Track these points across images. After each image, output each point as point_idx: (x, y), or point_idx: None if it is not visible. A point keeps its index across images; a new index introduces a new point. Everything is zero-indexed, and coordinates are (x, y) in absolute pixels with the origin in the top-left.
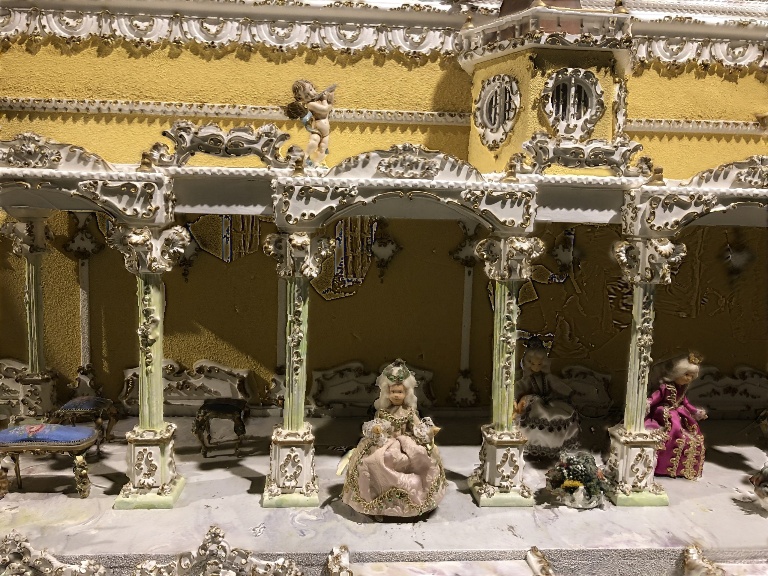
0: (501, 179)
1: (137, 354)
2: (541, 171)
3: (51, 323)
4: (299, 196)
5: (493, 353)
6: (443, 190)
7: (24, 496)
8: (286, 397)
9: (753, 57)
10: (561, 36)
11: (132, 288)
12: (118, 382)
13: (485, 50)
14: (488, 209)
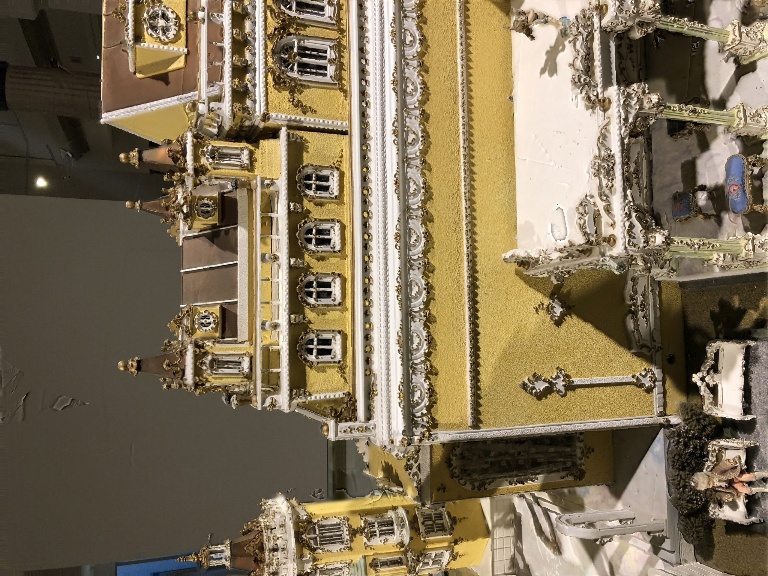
0: None
1: None
2: None
3: None
4: (621, 5)
5: None
6: None
7: (767, 197)
8: (712, 37)
9: None
10: None
11: None
12: None
13: None
14: None
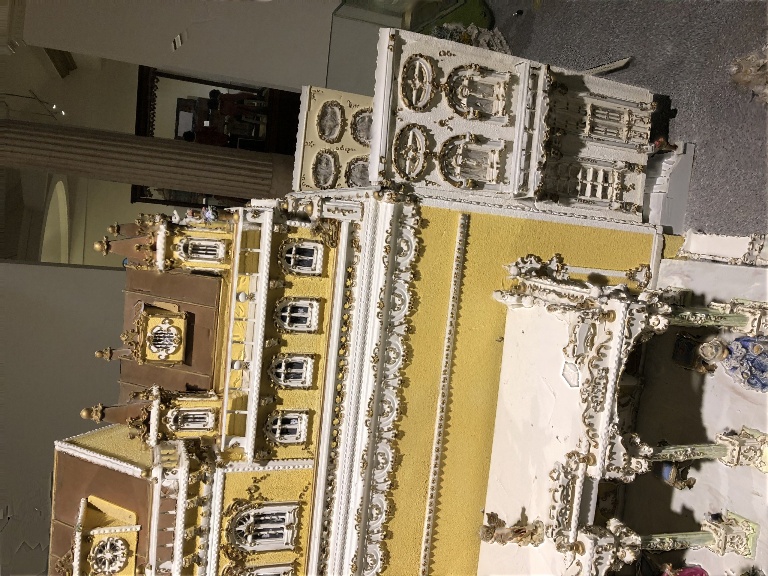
0: None
1: None
2: None
3: None
4: None
5: None
6: None
7: None
8: None
9: (387, 446)
10: None
11: None
12: None
13: None
14: None
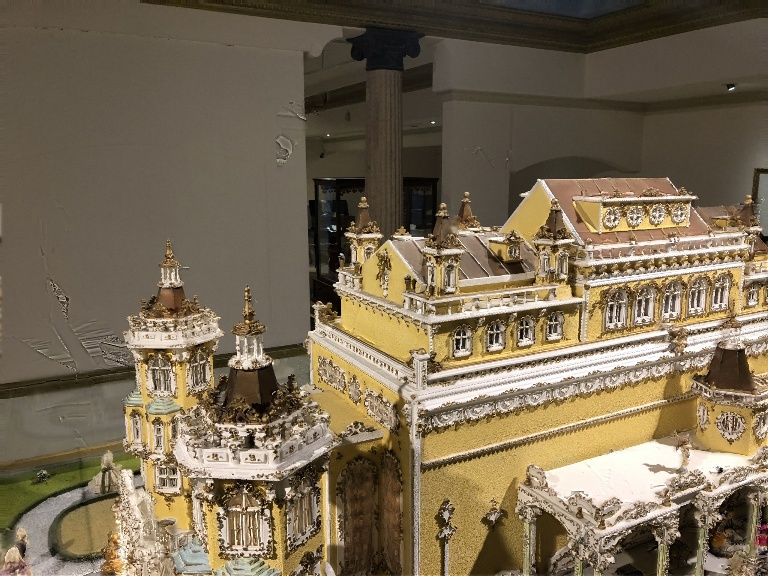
0: (759, 469)
1: (552, 548)
2: (766, 461)
3: (518, 546)
4: None
5: (752, 531)
6: (750, 482)
7: None
8: (699, 571)
9: (763, 347)
10: (764, 404)
11: (552, 517)
12: (544, 565)
13: (729, 404)
14: (763, 486)
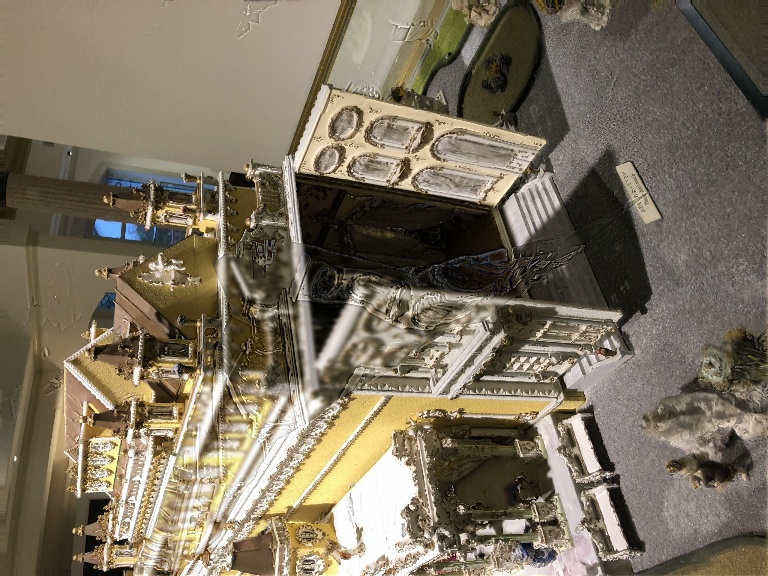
0: None
1: None
2: None
3: None
4: None
5: None
6: None
7: None
8: None
9: None
10: None
11: None
12: None
13: None
14: None
